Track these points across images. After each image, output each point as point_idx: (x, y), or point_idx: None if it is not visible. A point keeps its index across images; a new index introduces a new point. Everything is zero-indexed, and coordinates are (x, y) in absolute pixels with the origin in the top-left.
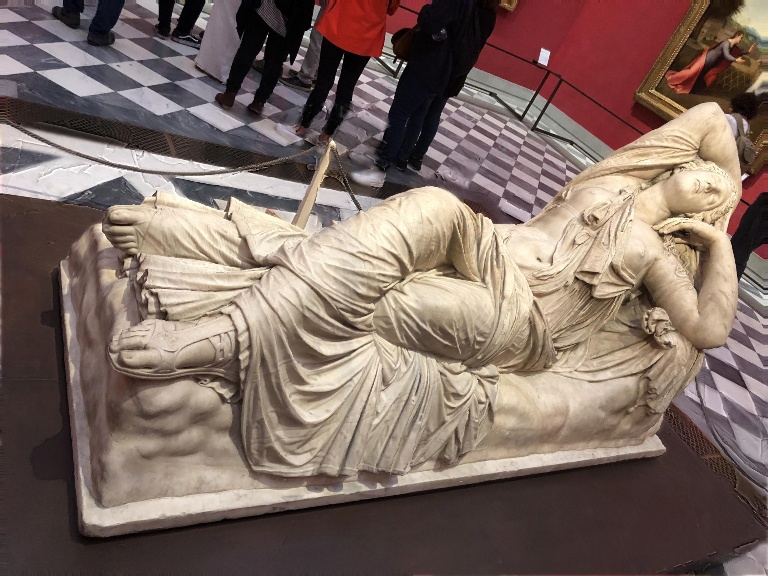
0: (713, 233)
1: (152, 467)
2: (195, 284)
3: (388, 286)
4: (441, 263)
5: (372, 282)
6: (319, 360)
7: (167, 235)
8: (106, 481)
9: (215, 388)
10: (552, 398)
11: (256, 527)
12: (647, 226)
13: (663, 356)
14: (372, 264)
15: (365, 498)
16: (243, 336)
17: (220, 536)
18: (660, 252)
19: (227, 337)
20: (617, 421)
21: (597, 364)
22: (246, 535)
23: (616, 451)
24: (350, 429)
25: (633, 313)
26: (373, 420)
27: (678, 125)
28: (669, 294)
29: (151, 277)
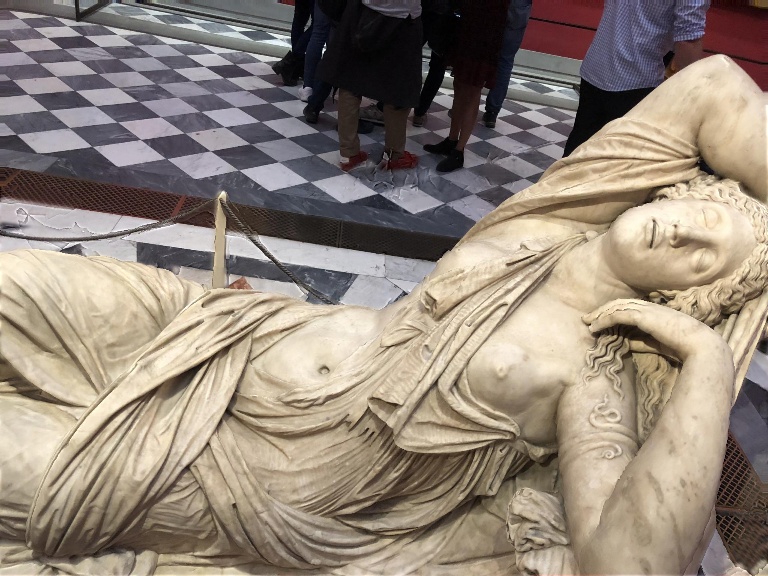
0: (682, 336)
1: None
2: None
3: None
4: None
5: None
6: None
7: None
8: None
9: None
10: None
11: None
12: (568, 315)
13: None
14: None
15: None
16: None
17: None
18: (574, 369)
19: None
20: None
21: None
22: None
23: None
24: None
25: (551, 485)
26: None
27: (637, 112)
28: (566, 462)
29: None
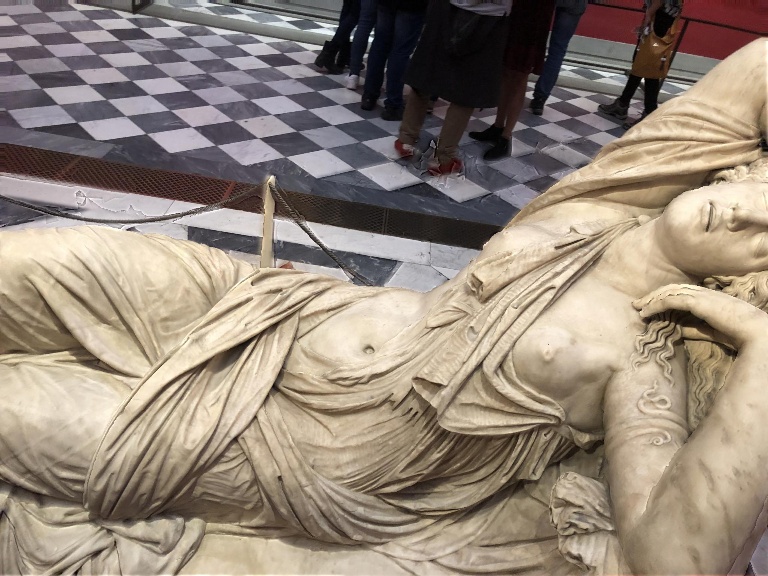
0: (737, 322)
1: None
2: None
3: None
4: None
5: None
6: None
7: None
8: None
9: None
10: None
11: None
12: (618, 300)
13: None
14: None
15: None
16: None
17: None
18: (623, 355)
19: None
20: None
21: (477, 559)
22: None
23: None
24: None
25: (596, 472)
26: None
27: (696, 92)
28: (612, 448)
29: None
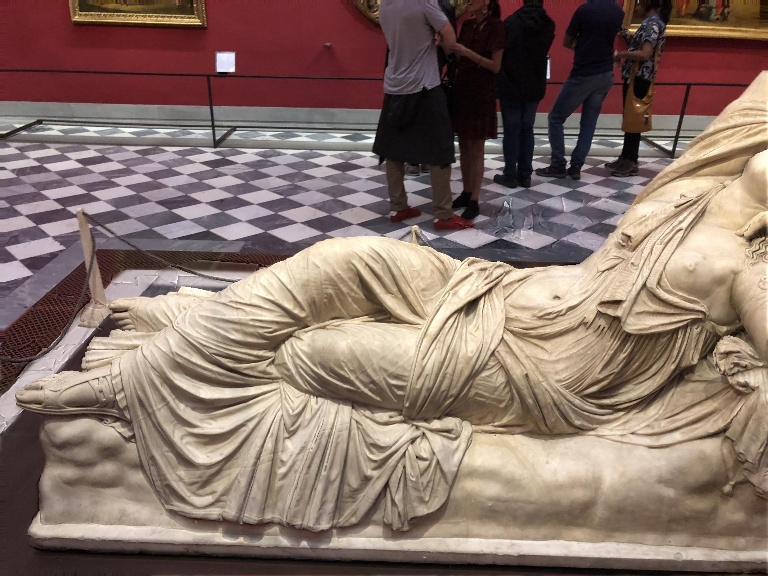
0: None
1: (76, 494)
2: (118, 345)
3: (277, 332)
4: (375, 309)
5: (247, 328)
6: (208, 404)
7: (150, 316)
8: (41, 501)
9: (115, 427)
10: (570, 465)
11: (173, 566)
12: (725, 233)
13: (743, 404)
14: (245, 311)
15: (294, 557)
16: (117, 379)
17: (139, 568)
18: (740, 262)
19: (105, 380)
20: (708, 505)
21: (666, 424)
22: (160, 571)
23: (733, 555)
24: (244, 474)
25: None
26: (279, 469)
27: (747, 95)
28: (749, 316)
29: (92, 342)
